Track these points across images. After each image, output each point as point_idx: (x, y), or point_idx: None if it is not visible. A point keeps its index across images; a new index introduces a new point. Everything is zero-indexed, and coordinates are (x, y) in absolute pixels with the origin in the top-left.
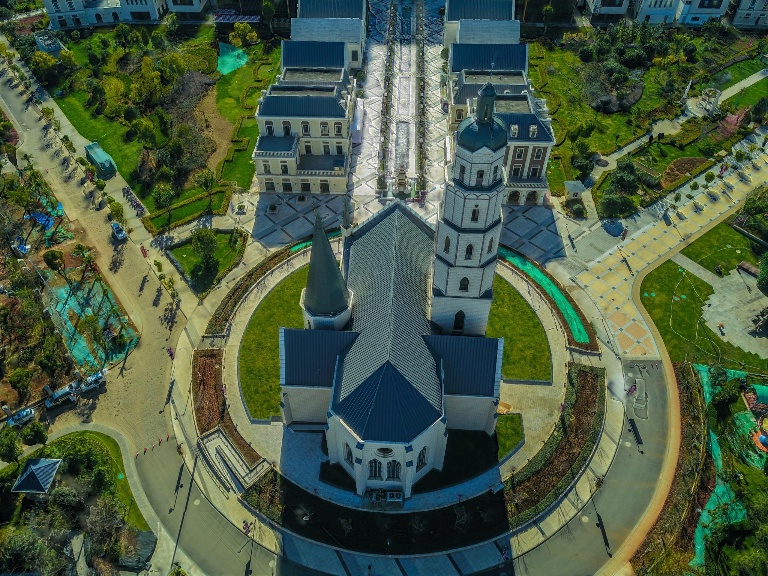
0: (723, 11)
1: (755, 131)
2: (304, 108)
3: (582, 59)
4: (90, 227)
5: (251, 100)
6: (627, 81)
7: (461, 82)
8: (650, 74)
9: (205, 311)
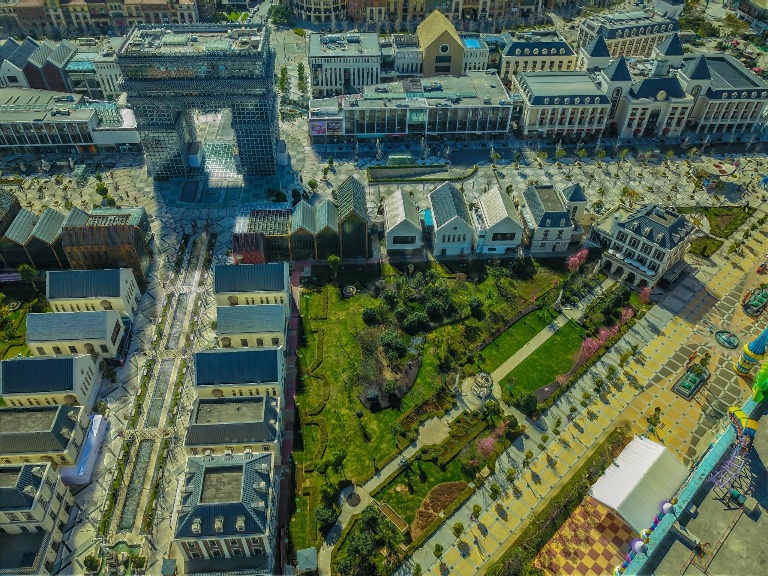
0: (518, 242)
1: (524, 431)
2: None
3: (365, 321)
4: None
5: None
6: (404, 357)
7: (192, 419)
8: None
9: None
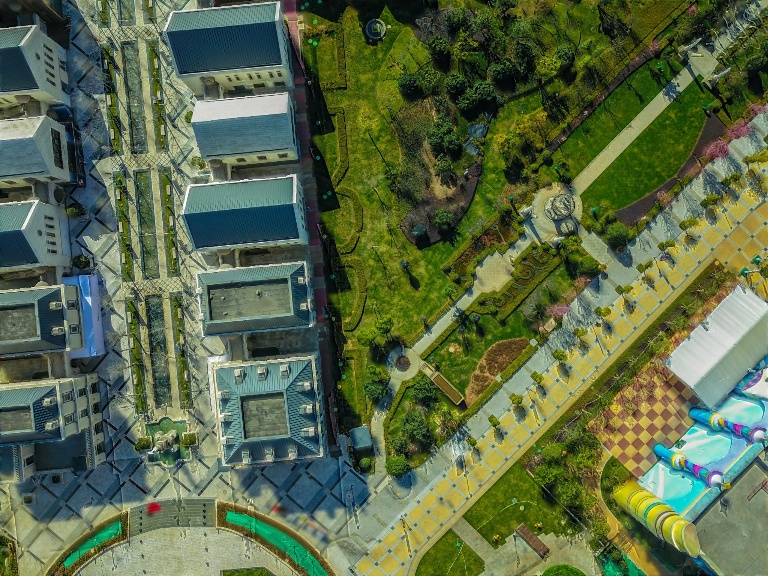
0: None
1: None
2: (3, 440)
3: (402, 95)
4: None
5: None
6: (459, 160)
7: (205, 312)
8: (496, 130)
9: None
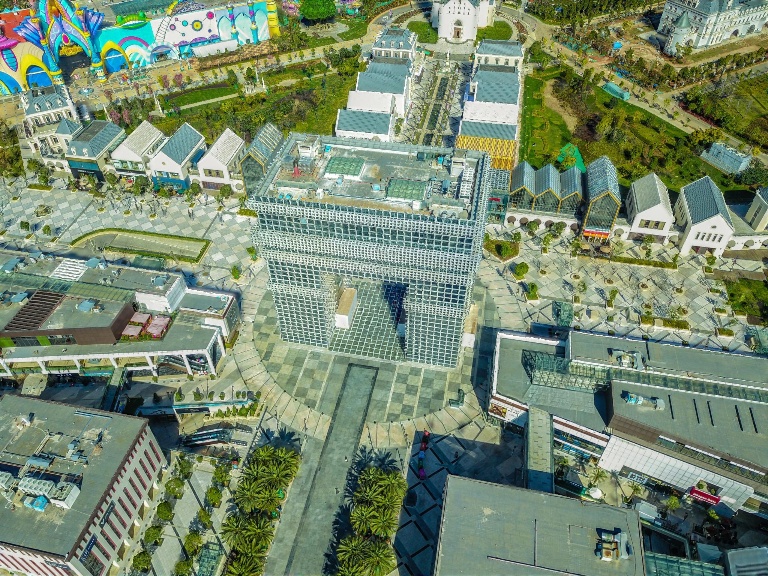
0: None
1: None
2: None
3: None
4: (597, 68)
5: (541, 121)
6: None
7: None
8: None
9: (529, 43)
